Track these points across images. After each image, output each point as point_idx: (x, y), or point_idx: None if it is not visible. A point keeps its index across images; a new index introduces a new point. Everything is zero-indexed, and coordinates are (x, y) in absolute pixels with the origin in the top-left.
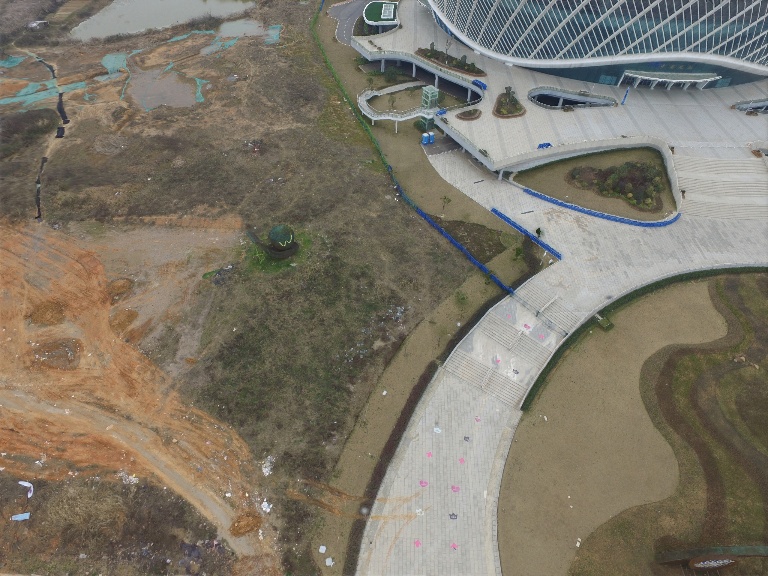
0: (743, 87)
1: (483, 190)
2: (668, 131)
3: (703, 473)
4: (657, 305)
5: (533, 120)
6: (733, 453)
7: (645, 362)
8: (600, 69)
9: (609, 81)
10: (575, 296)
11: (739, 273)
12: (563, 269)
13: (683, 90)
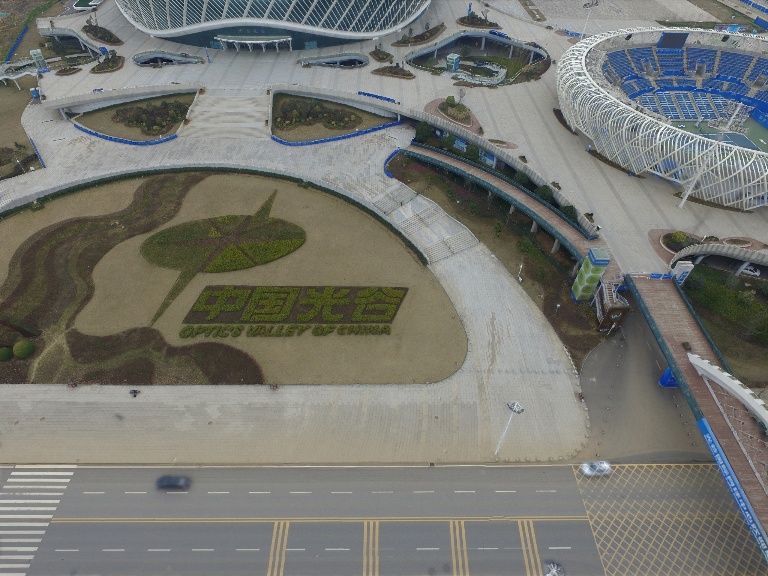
0: (329, 48)
1: (43, 126)
2: (221, 79)
3: (14, 289)
4: (91, 194)
5: (118, 74)
6: (49, 277)
7: (43, 228)
8: (202, 35)
9: (217, 46)
10: (27, 189)
11: (178, 172)
12: (39, 173)
13: (276, 51)
